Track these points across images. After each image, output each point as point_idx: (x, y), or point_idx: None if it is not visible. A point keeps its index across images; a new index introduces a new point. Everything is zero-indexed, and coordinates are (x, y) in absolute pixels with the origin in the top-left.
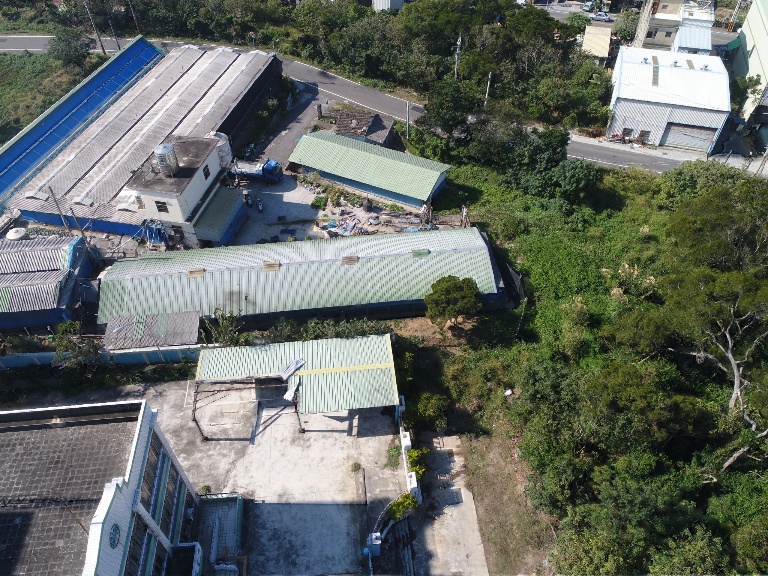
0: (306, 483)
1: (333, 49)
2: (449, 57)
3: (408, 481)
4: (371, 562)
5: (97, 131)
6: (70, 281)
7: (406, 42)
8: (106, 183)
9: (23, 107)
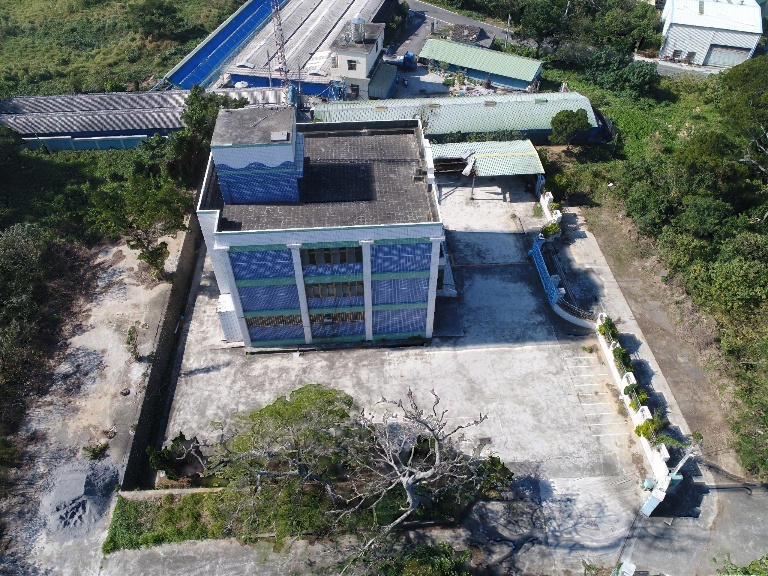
0: (481, 223)
1: None
2: None
3: (554, 217)
4: None
5: None
6: None
7: None
8: (294, 59)
9: (204, 16)
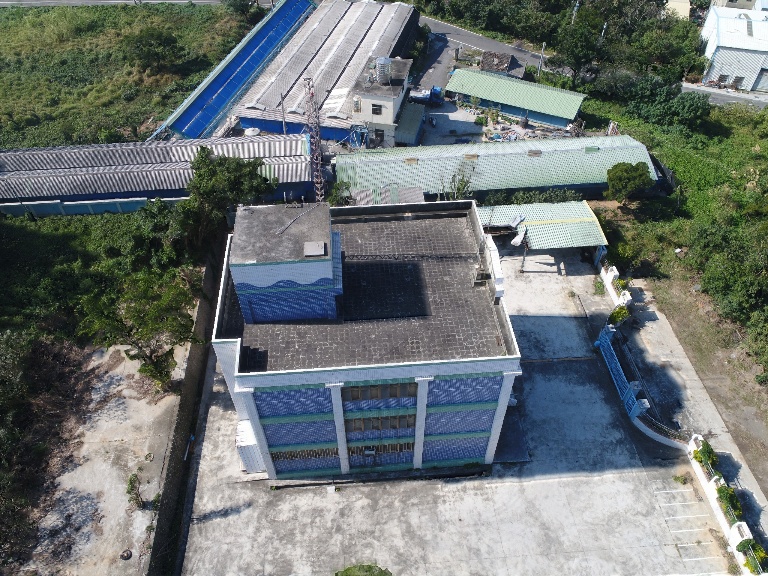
0: (536, 303)
1: (455, 5)
2: (557, 14)
3: (621, 298)
4: None
5: (286, 61)
6: None
7: (513, 3)
8: None
9: (207, 45)
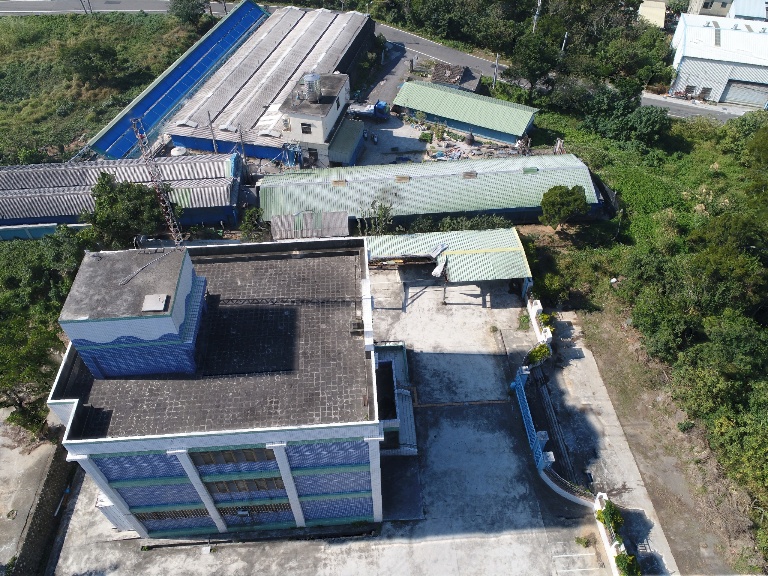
0: (454, 339)
1: (416, 14)
2: (522, 22)
3: (543, 335)
4: (519, 391)
5: (227, 74)
6: (235, 186)
7: (479, 10)
8: (245, 115)
9: (151, 57)
